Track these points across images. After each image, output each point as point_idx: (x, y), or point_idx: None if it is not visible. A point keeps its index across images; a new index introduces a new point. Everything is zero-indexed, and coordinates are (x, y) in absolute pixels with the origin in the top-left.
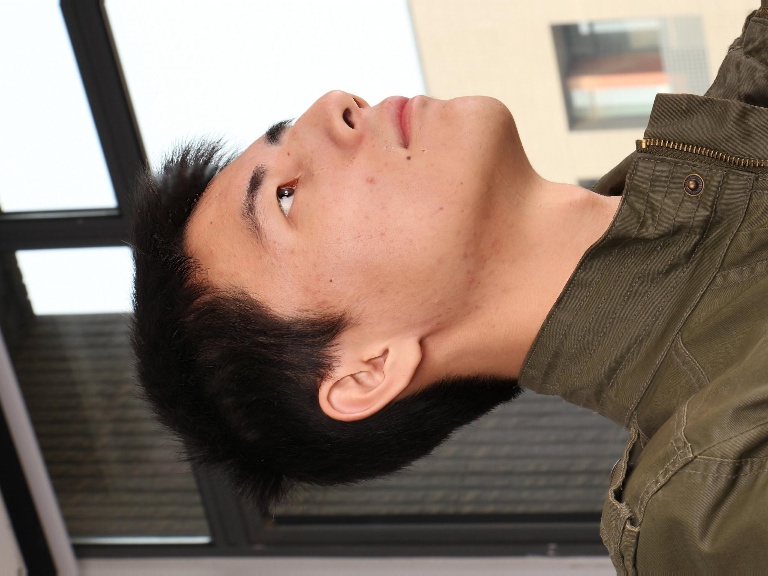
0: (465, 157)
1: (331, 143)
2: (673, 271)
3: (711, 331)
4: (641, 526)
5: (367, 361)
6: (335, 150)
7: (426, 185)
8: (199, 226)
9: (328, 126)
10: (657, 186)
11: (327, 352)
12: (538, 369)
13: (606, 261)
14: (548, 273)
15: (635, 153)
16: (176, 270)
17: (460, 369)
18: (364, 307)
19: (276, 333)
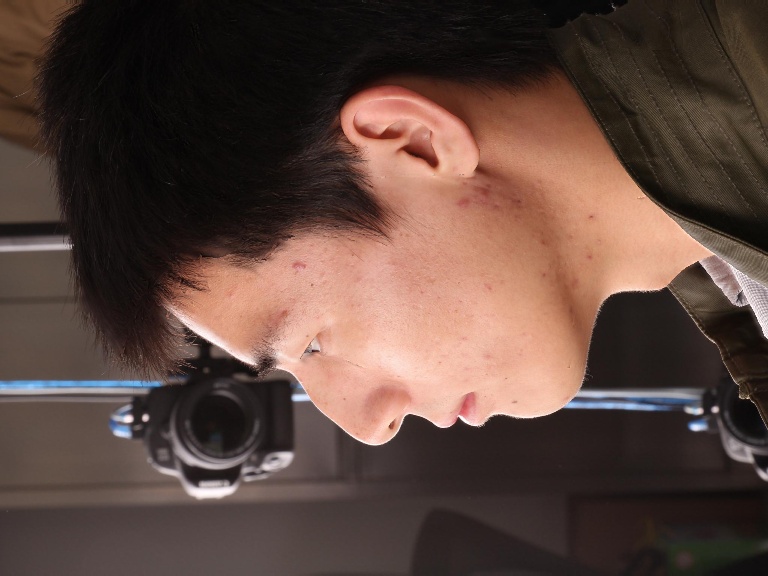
0: None
1: None
2: None
3: None
4: None
5: None
6: None
7: None
8: None
9: None
10: None
11: None
12: None
13: None
14: None
15: None
16: None
17: None
18: None
19: None
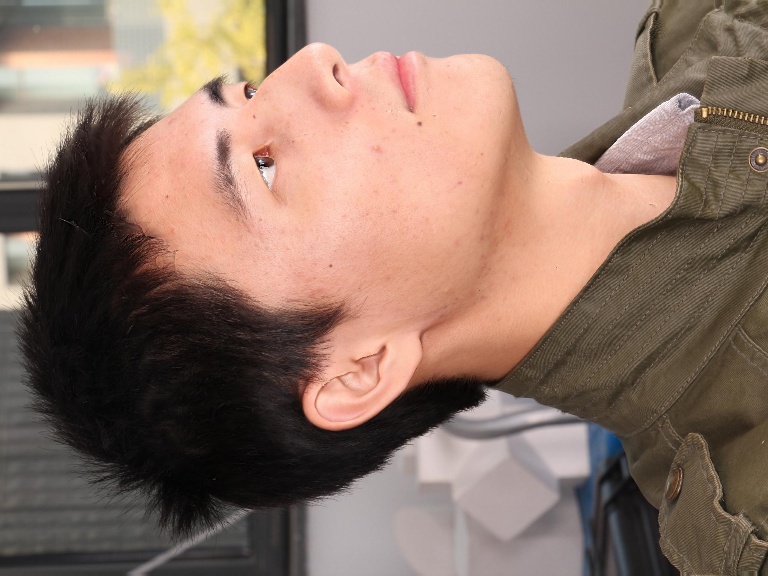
0: (484, 124)
1: (315, 105)
2: (729, 256)
3: None
4: None
5: (357, 360)
6: (320, 113)
7: (442, 155)
8: (148, 200)
9: (315, 85)
10: (719, 160)
11: (315, 350)
12: (539, 369)
13: (648, 245)
14: (561, 259)
15: (693, 123)
16: (131, 252)
17: (448, 369)
18: (366, 297)
19: (263, 327)
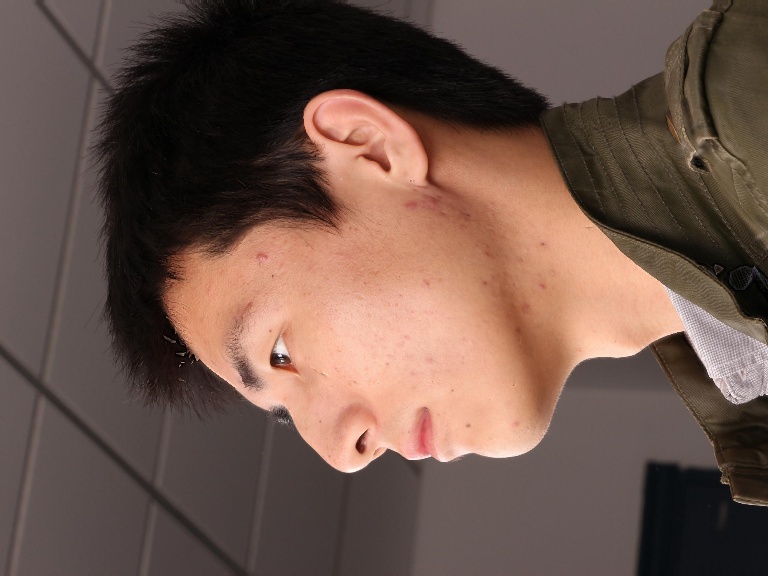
0: None
1: None
2: None
3: None
4: None
5: None
6: None
7: None
8: None
9: None
10: None
11: None
12: None
13: None
14: None
15: None
16: None
17: None
18: None
19: None
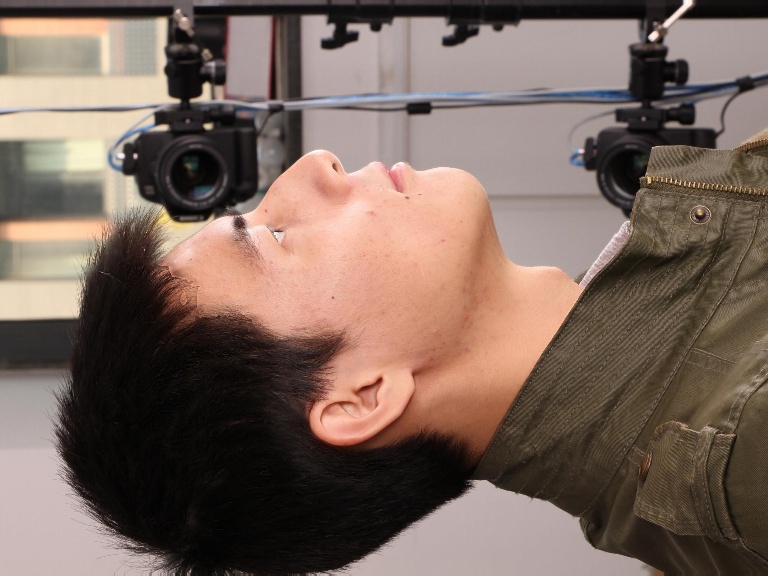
0: (462, 201)
1: (318, 193)
2: (679, 298)
3: (740, 325)
4: (736, 432)
5: (357, 392)
6: (322, 200)
7: (427, 219)
8: (174, 265)
9: (317, 175)
10: (665, 216)
11: (320, 375)
12: (519, 424)
13: (608, 293)
14: (534, 326)
15: None
16: (159, 291)
17: (438, 423)
18: (364, 327)
19: (274, 344)
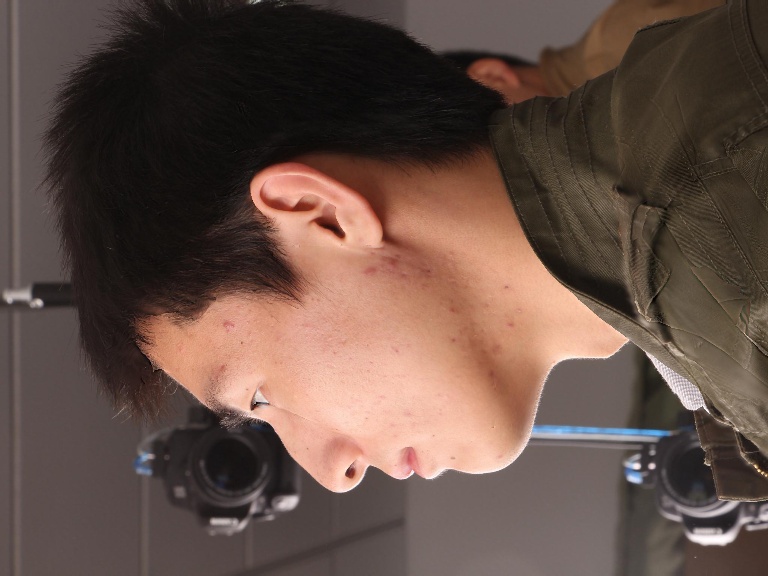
0: None
1: None
2: None
3: None
4: None
5: None
6: None
7: None
8: None
9: None
10: None
11: None
12: None
13: None
14: None
15: None
16: None
17: None
18: None
19: None
